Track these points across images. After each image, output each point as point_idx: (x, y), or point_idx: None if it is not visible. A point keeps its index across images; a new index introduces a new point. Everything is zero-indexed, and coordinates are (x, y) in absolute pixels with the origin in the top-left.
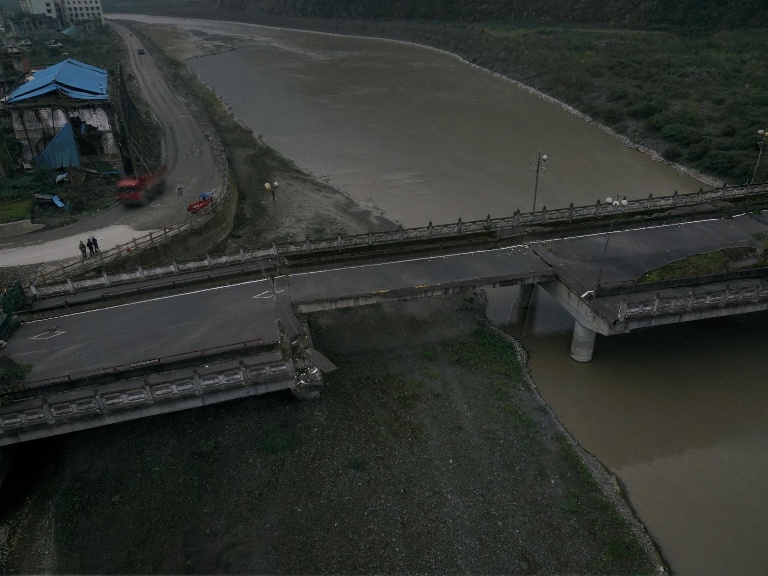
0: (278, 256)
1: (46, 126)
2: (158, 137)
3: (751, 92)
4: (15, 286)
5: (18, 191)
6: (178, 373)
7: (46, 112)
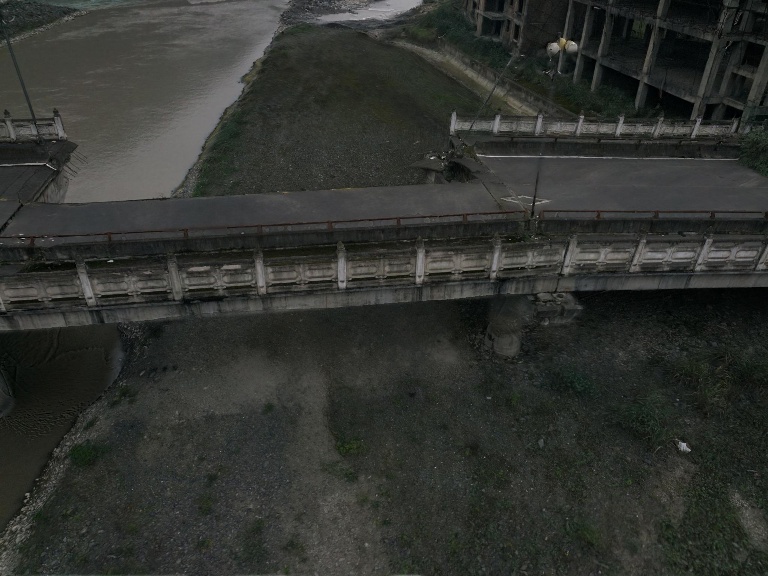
0: None
1: None
2: None
3: None
4: None
5: None
6: None
7: None
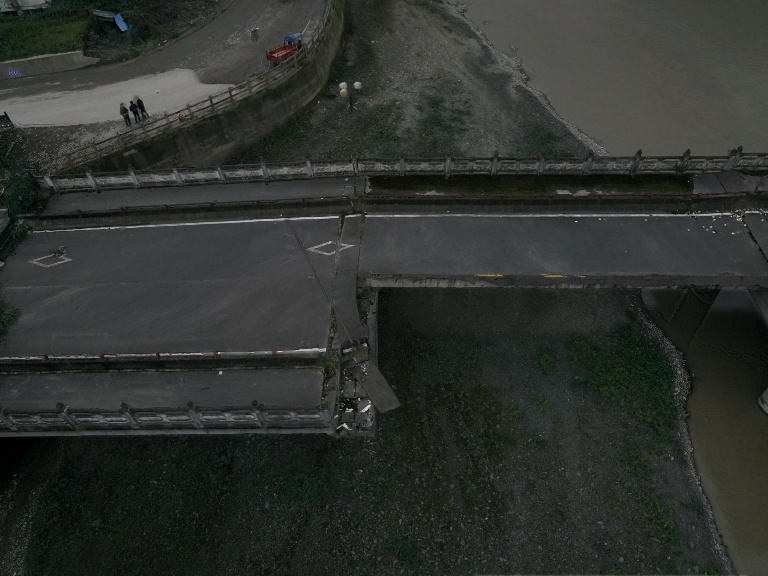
0: (358, 176)
1: None
2: None
3: None
4: (33, 168)
5: (76, 3)
6: (182, 376)
7: None
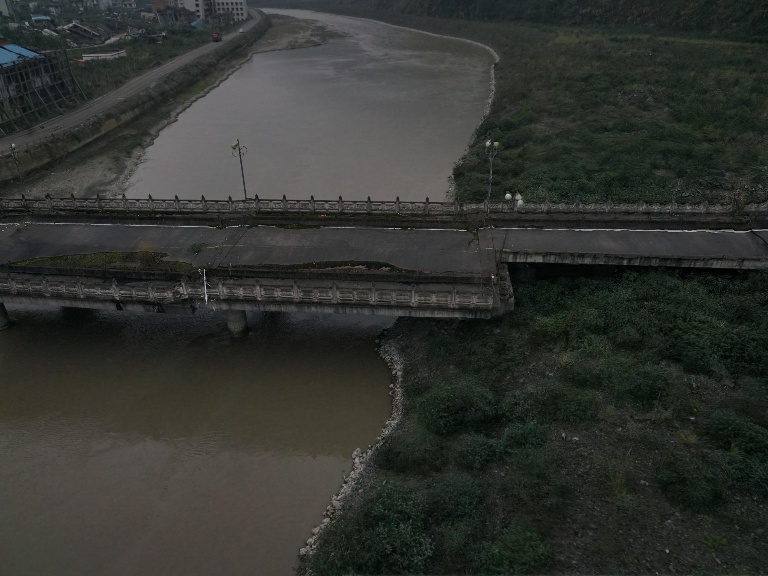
0: None
1: None
2: (58, 113)
3: (658, 117)
4: None
5: None
6: None
7: None
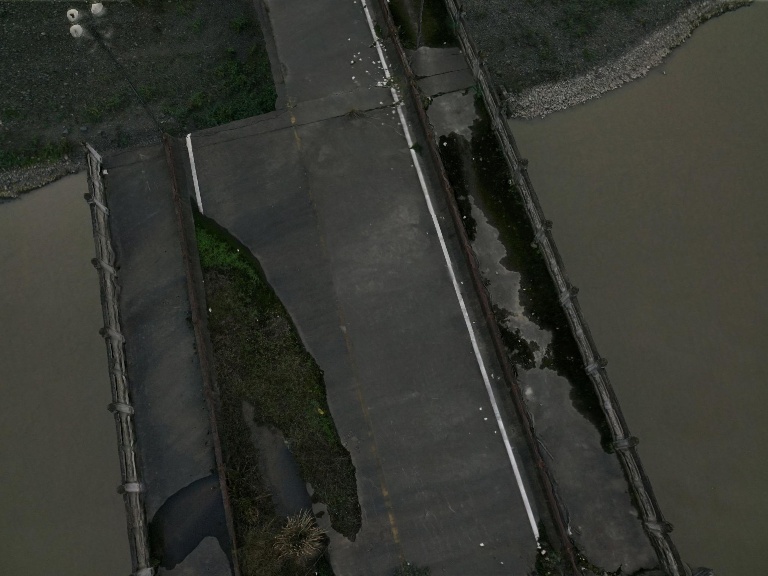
0: None
1: None
2: None
3: None
4: None
5: None
6: None
7: None
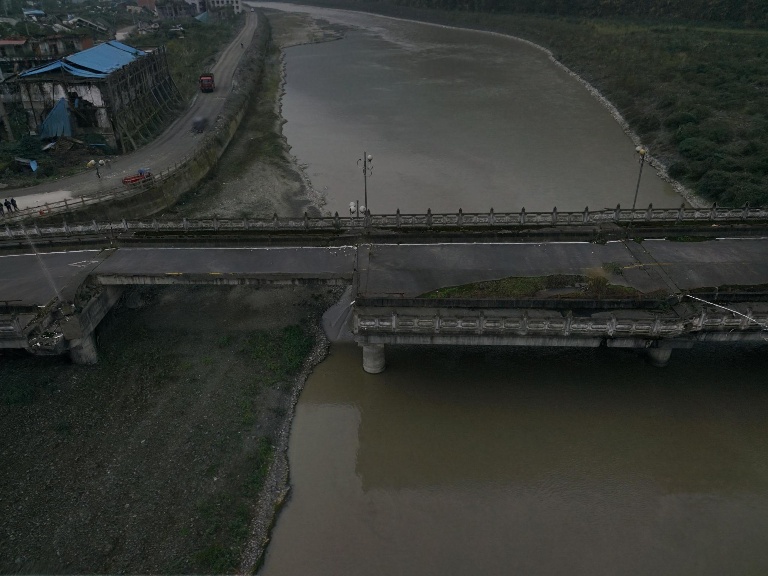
0: None
1: (49, 99)
2: (175, 116)
3: None
4: None
5: (5, 154)
6: None
7: (49, 86)
